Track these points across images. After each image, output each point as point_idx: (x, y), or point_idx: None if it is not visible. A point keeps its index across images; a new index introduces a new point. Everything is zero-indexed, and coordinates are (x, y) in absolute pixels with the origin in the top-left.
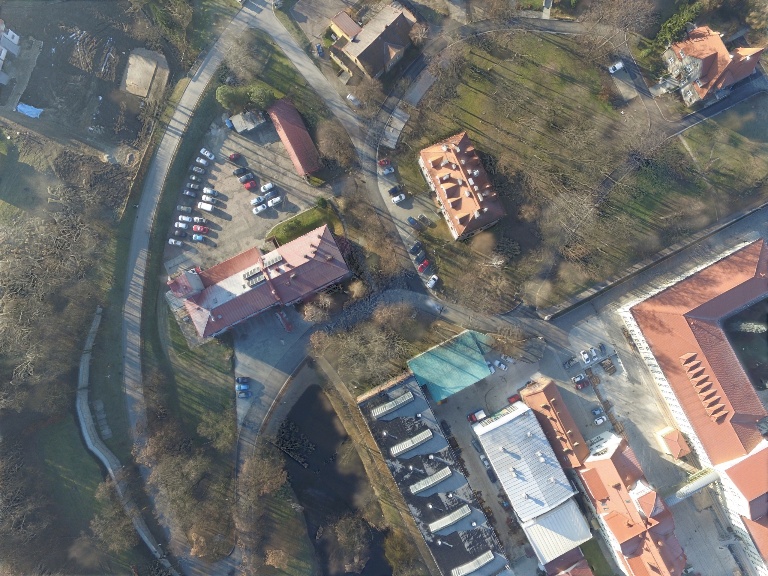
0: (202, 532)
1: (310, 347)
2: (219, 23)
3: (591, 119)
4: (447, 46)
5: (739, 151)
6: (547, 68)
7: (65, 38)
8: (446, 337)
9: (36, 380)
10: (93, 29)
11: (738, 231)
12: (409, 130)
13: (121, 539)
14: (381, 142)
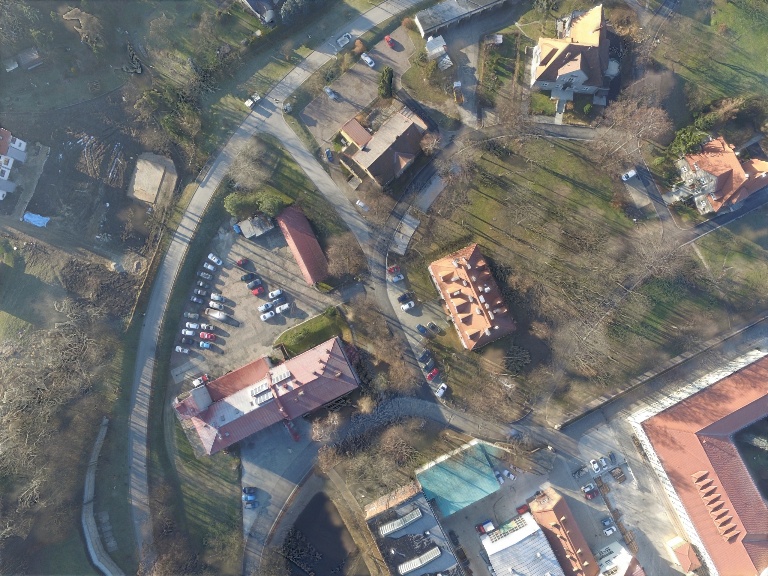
0: None
1: (317, 456)
2: (228, 127)
3: (603, 226)
4: (458, 151)
5: (752, 259)
6: (559, 174)
7: (72, 143)
8: (455, 446)
9: (42, 505)
10: (101, 134)
11: (750, 337)
12: (419, 237)
13: None
14: (390, 248)
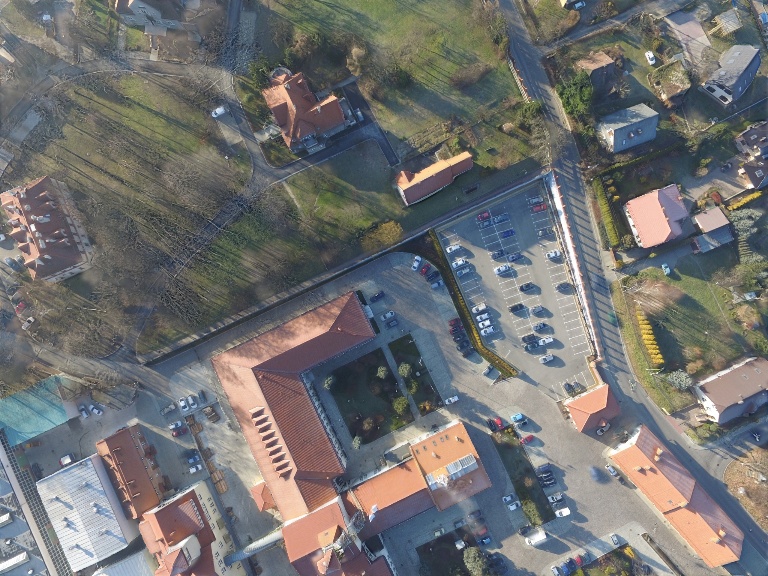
0: None
1: None
2: None
3: (196, 163)
4: (54, 86)
5: (345, 199)
6: (153, 110)
7: None
8: None
9: None
10: None
11: (354, 280)
12: (10, 170)
13: None
14: None
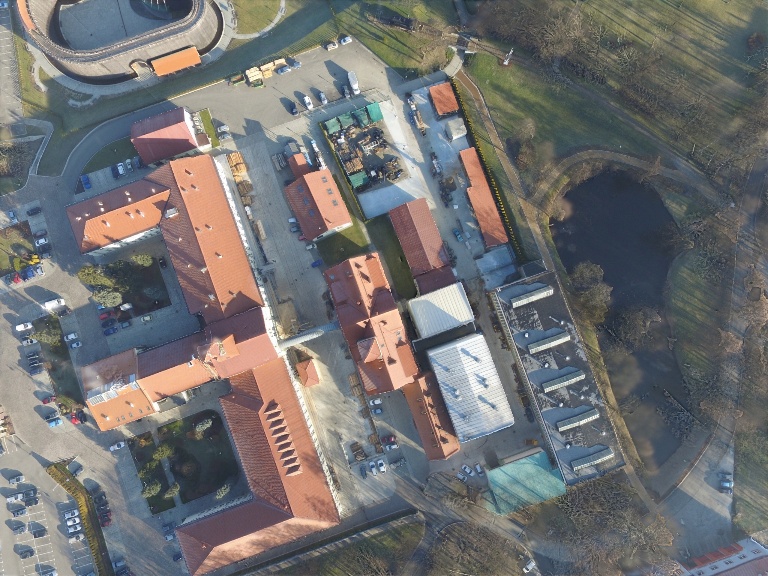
0: None
1: (656, 513)
2: None
3: None
4: None
5: None
6: None
7: None
8: None
9: None
10: None
11: (203, 575)
12: None
13: None
14: None
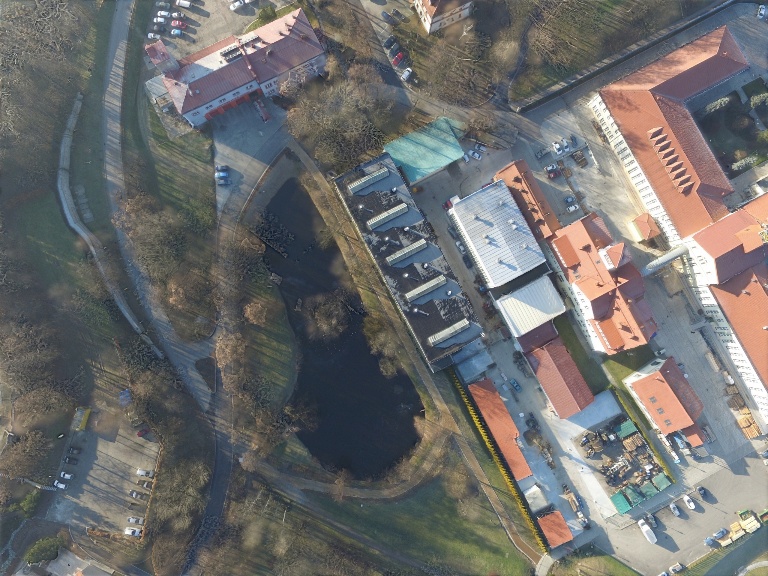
0: (183, 313)
1: (288, 138)
2: None
3: None
4: None
5: None
6: None
7: None
8: None
9: (16, 140)
10: None
11: (703, 30)
12: None
13: (103, 313)
14: None
